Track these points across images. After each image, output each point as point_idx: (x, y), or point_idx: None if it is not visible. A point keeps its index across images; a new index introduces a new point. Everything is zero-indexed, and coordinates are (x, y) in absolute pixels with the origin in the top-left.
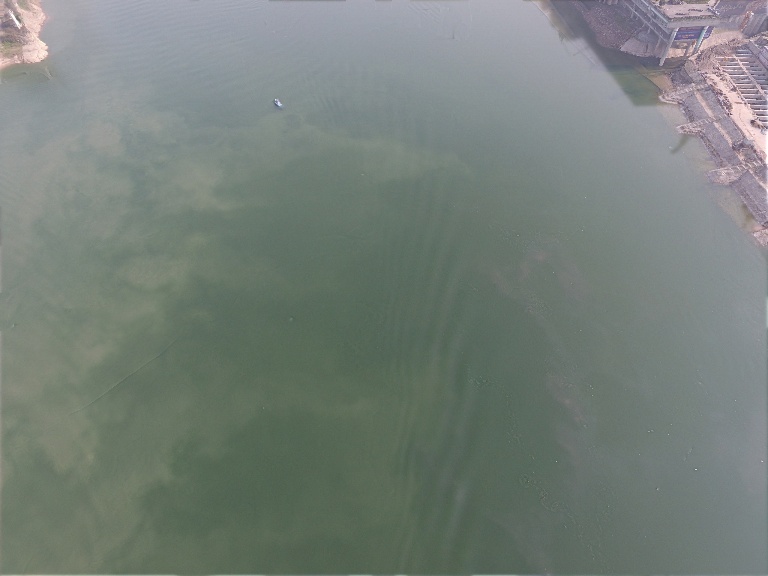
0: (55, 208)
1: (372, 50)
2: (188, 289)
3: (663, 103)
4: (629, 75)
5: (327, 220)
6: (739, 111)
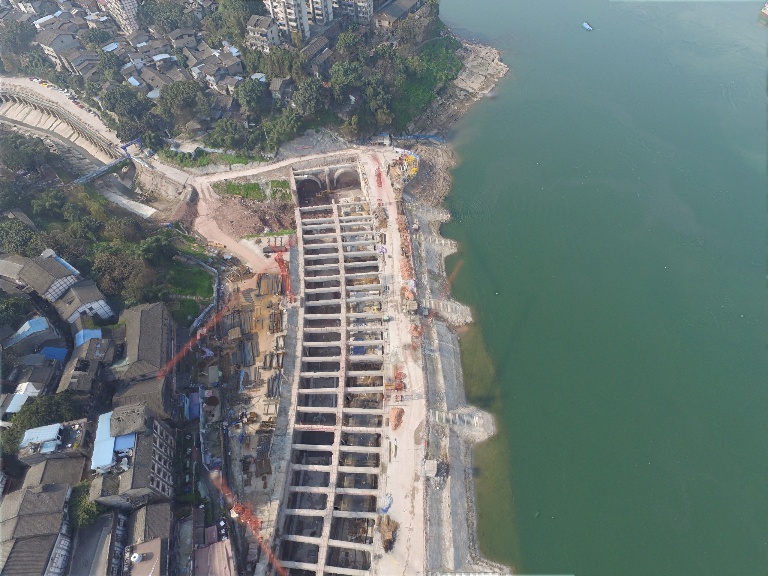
0: None
1: None
2: None
3: None
4: None
5: None
6: None
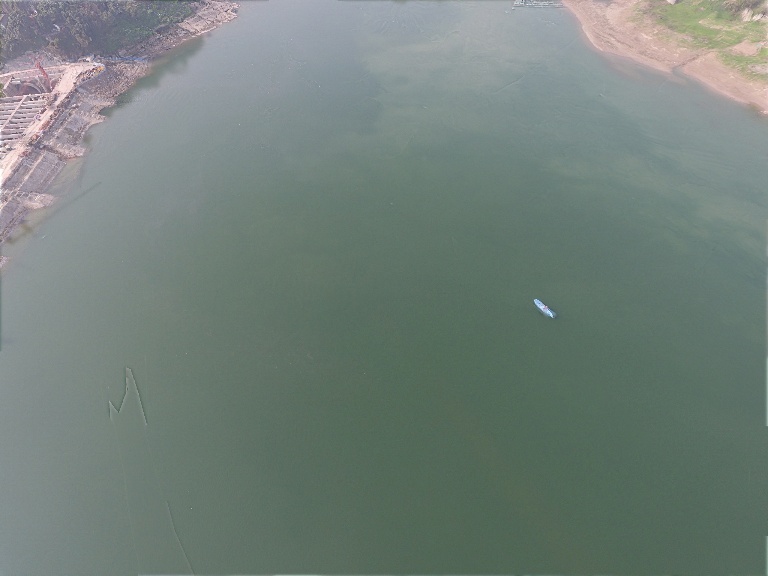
0: (683, 160)
1: None
2: (504, 117)
3: None
4: None
5: (418, 161)
6: None
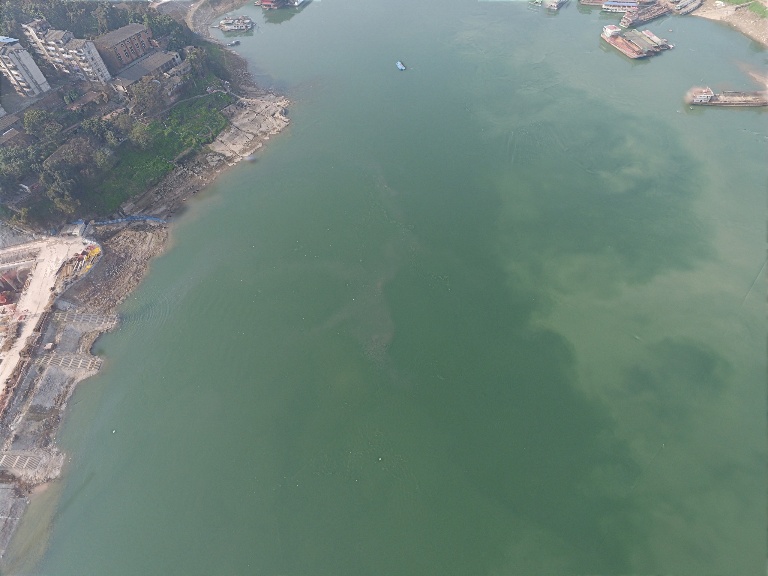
0: None
1: None
2: None
3: None
4: None
5: (685, 508)
6: None
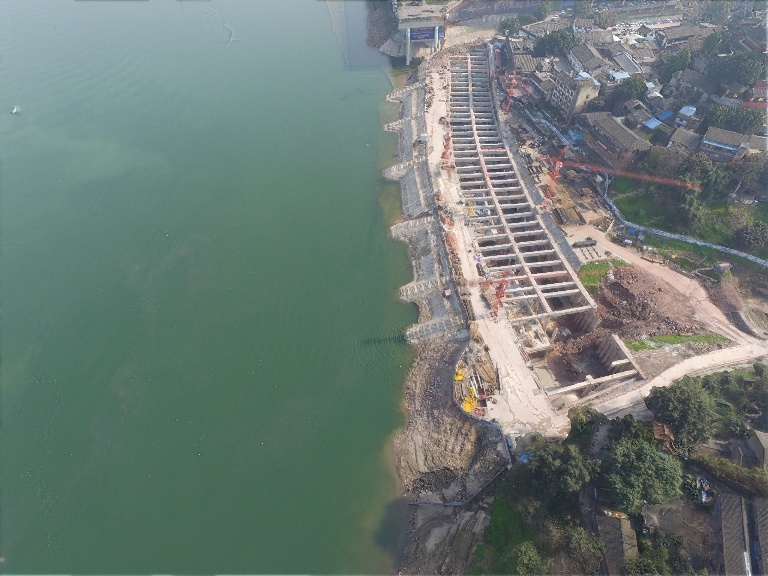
0: None
1: (148, 54)
2: None
3: (387, 102)
4: (373, 75)
5: None
6: (436, 108)
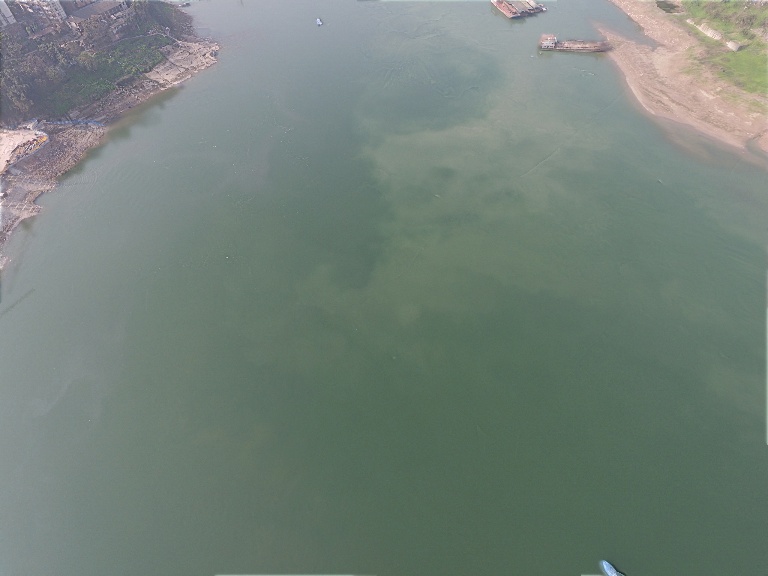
0: None
1: None
2: (538, 213)
3: None
4: None
5: (429, 284)
6: None
